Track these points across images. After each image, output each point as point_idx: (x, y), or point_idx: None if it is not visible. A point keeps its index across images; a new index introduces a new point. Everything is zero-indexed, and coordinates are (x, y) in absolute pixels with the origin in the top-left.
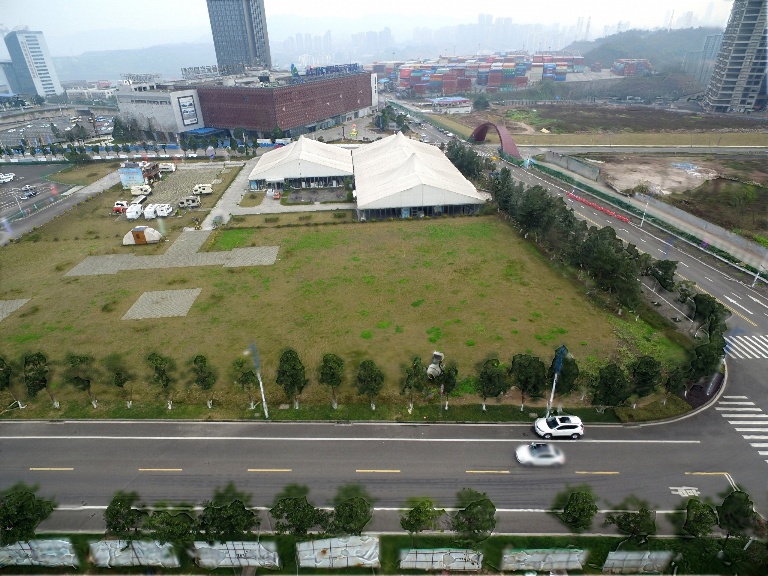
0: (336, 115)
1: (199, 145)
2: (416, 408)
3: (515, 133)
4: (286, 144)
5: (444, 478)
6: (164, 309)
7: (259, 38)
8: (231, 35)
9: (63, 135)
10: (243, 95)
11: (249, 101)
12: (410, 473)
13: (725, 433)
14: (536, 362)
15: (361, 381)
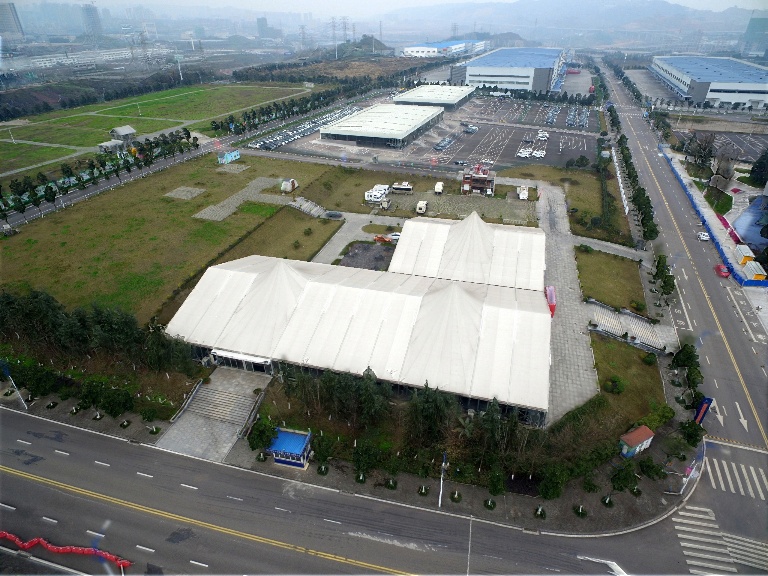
0: None
1: None
2: None
3: None
4: None
5: None
6: (177, 192)
7: None
8: None
9: None
10: None
11: None
12: None
13: None
14: None
15: None
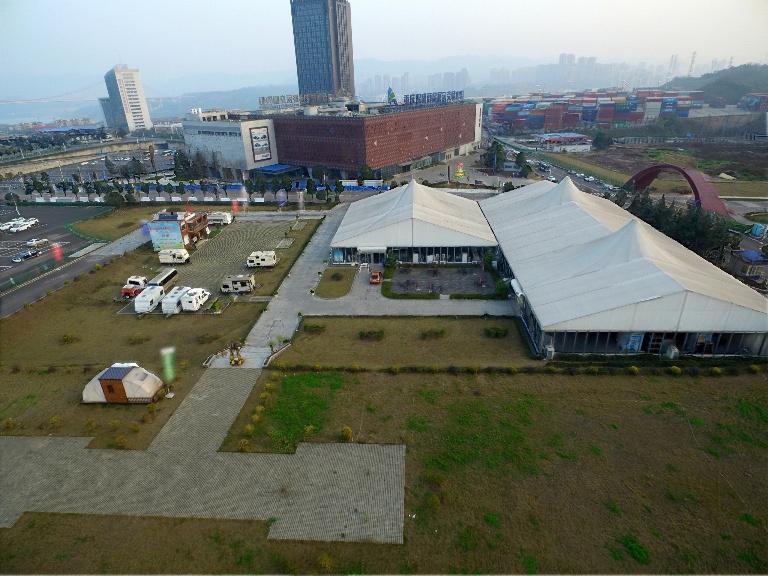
0: (434, 152)
1: (268, 187)
2: None
3: (684, 179)
4: (377, 187)
5: None
6: None
7: (344, 71)
8: (316, 68)
9: (117, 170)
10: (327, 126)
11: (333, 133)
12: None
13: None
14: None
15: None
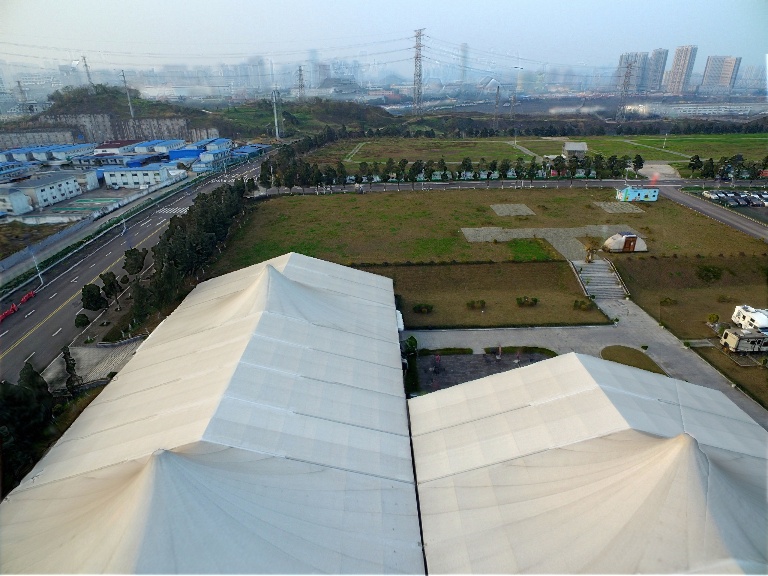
0: None
1: None
2: None
3: None
4: None
5: None
6: None
7: None
8: None
9: None
10: None
11: None
12: None
13: None
14: None
15: None
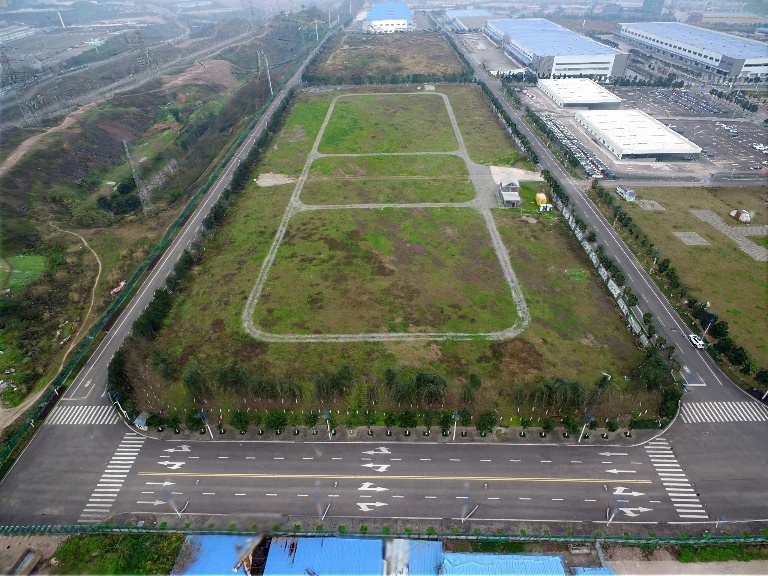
0: None
1: None
2: (680, 306)
3: None
4: None
5: (652, 311)
6: (687, 239)
7: None
8: None
9: None
10: None
11: None
12: (649, 304)
13: (735, 396)
14: (709, 314)
15: (671, 280)
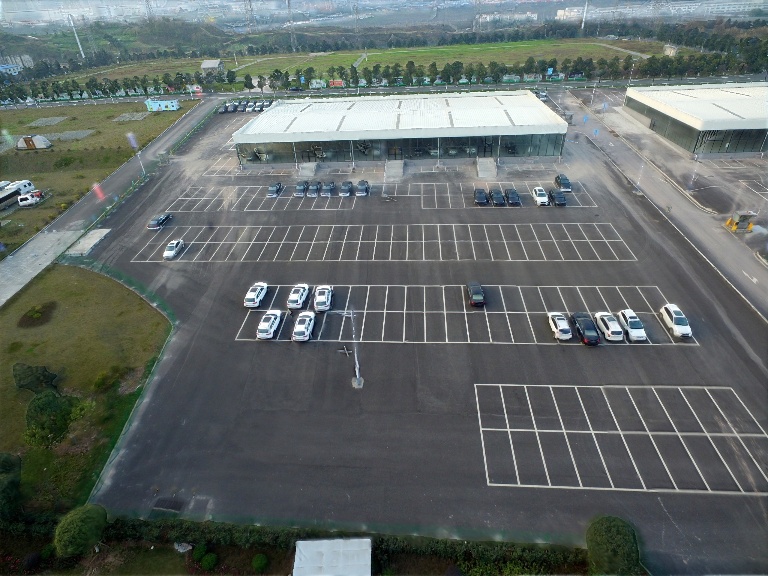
0: None
1: None
2: None
3: None
4: None
5: None
6: (49, 119)
7: None
8: None
9: None
10: None
11: None
12: None
13: None
14: None
15: None
